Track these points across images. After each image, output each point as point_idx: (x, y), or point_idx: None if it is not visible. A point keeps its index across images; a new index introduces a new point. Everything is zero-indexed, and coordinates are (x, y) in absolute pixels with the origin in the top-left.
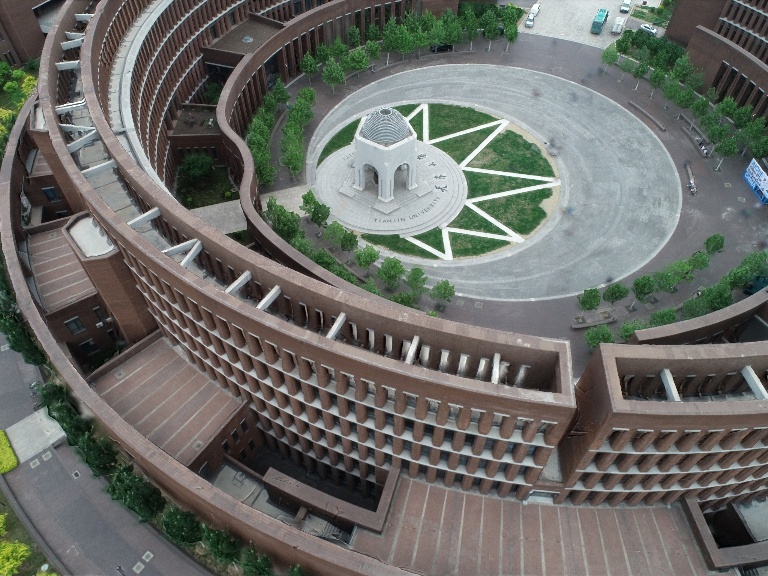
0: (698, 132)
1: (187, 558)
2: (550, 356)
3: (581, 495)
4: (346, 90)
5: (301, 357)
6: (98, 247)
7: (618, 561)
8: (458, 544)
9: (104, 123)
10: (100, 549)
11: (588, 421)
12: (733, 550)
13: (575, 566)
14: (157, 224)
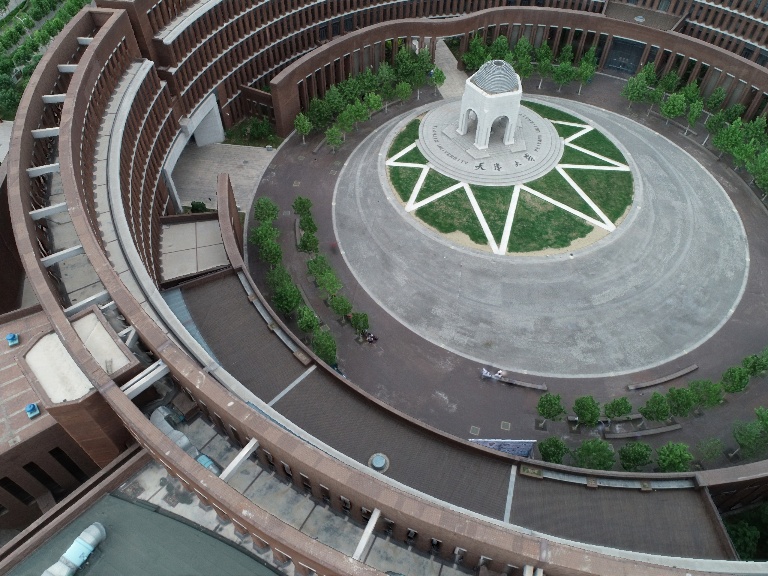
0: None
1: None
2: None
3: None
4: (636, 115)
5: None
6: None
7: None
8: None
9: None
10: None
11: None
12: None
13: None
14: None
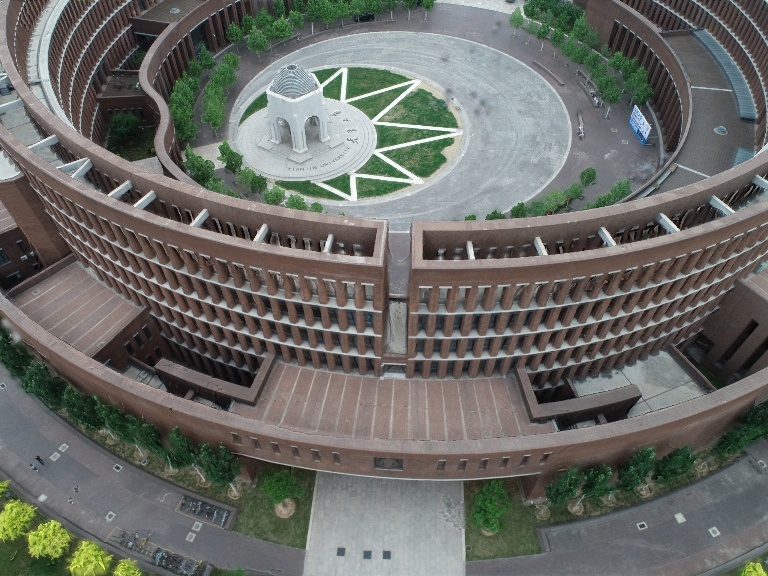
0: (593, 85)
1: (98, 447)
2: (372, 233)
3: (425, 366)
4: (272, 57)
5: (167, 245)
6: (7, 173)
7: (455, 419)
8: (320, 411)
9: (13, 68)
10: (21, 443)
11: (398, 281)
12: (550, 405)
13: (418, 424)
14: (61, 154)
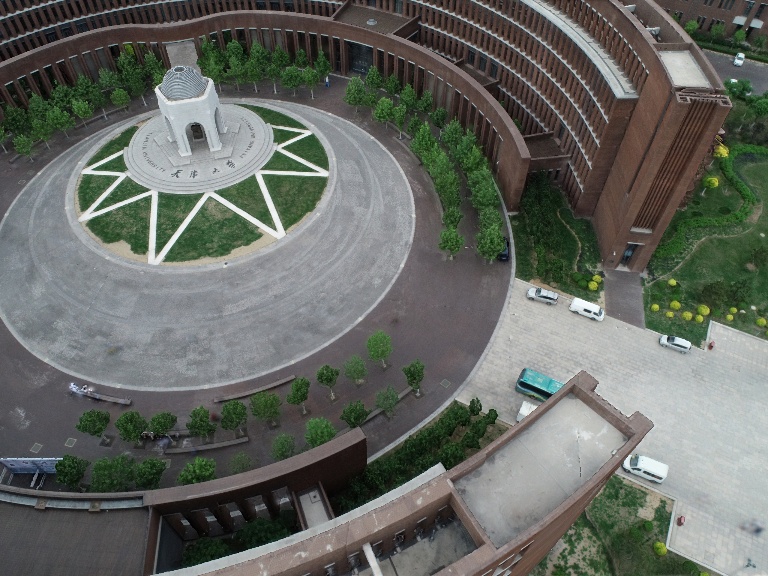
0: None
1: None
2: None
3: None
4: (360, 120)
5: None
6: None
7: None
8: None
9: None
10: None
11: None
12: None
13: None
14: None
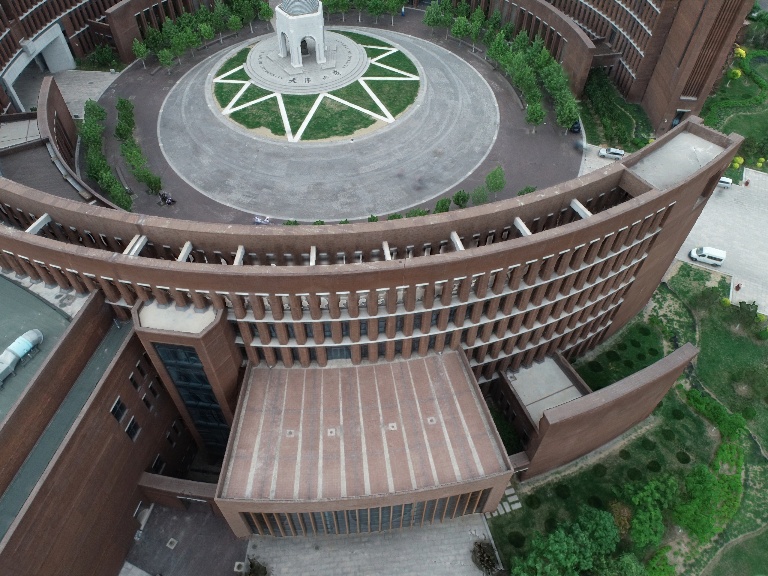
0: None
1: None
2: None
3: None
4: (436, 39)
5: None
6: None
7: None
8: None
9: None
10: None
11: None
12: None
13: None
14: None
